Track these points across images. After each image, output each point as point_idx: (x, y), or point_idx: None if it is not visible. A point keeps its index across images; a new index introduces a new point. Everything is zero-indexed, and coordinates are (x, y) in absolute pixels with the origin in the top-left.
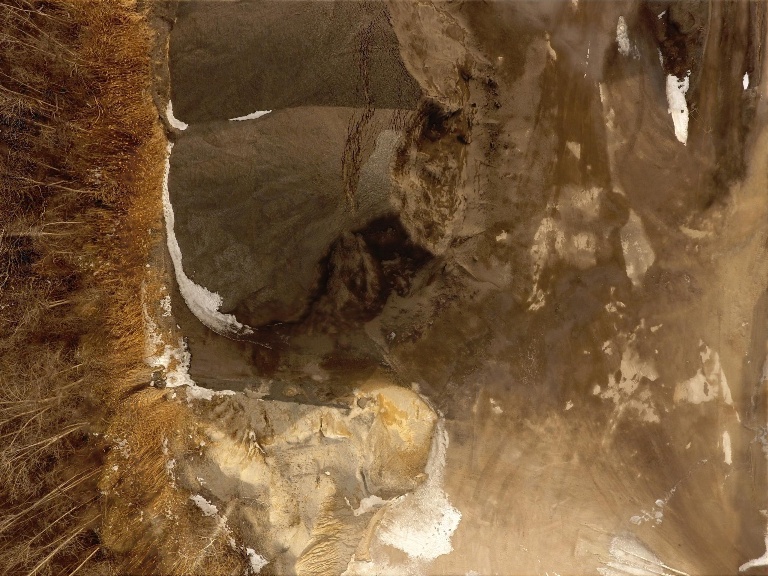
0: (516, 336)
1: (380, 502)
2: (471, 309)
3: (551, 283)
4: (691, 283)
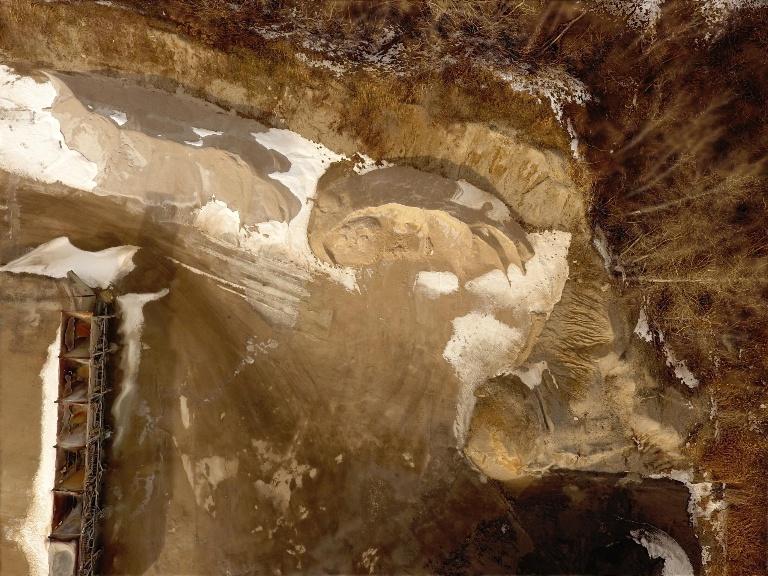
0: (389, 525)
1: (522, 374)
2: (431, 551)
3: (357, 573)
4: (225, 570)
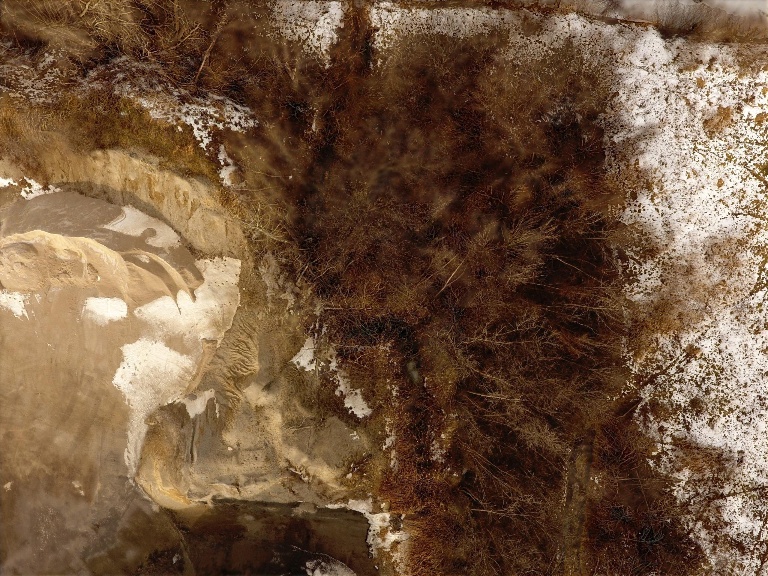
0: (59, 554)
1: (189, 402)
2: None
3: None
4: None
